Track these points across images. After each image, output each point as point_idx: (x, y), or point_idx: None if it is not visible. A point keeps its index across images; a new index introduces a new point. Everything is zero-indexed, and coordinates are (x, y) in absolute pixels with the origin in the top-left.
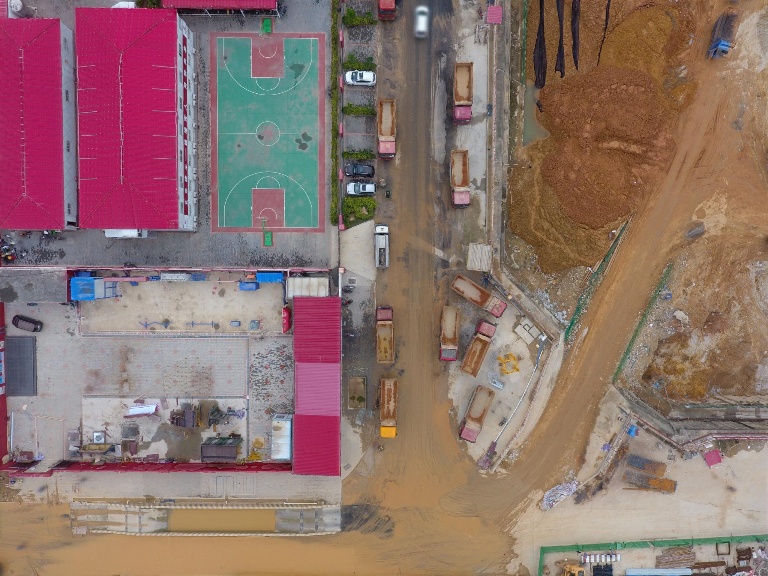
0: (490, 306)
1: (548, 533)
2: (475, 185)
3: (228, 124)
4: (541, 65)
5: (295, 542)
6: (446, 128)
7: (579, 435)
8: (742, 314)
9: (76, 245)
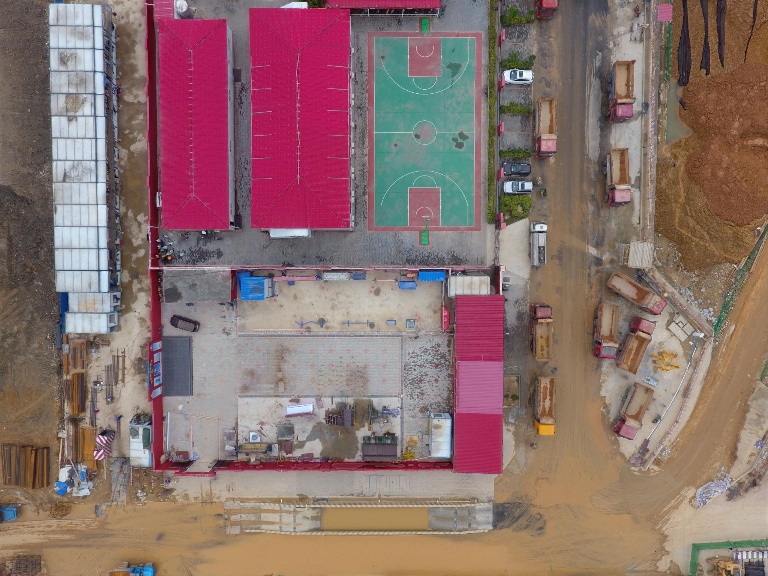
0: (651, 303)
1: (699, 530)
2: None
3: (385, 123)
4: (685, 63)
5: (447, 540)
6: (600, 126)
7: (729, 432)
8: None
9: (233, 245)
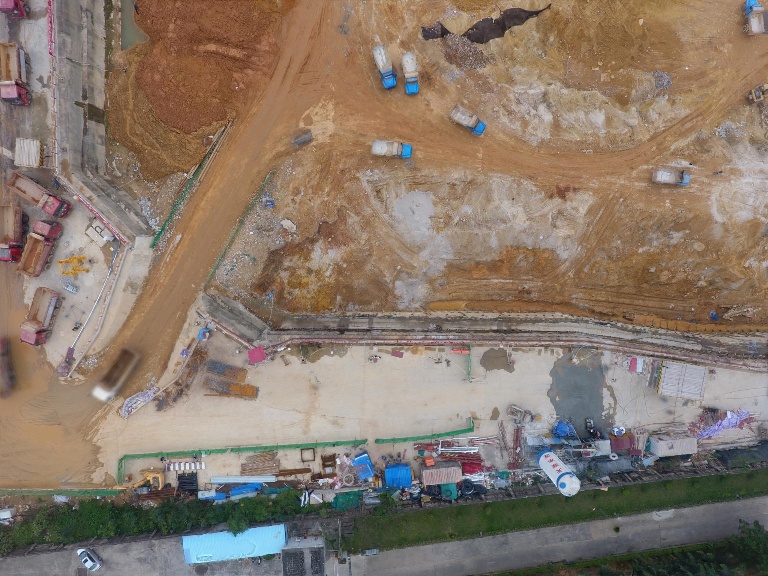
0: (40, 203)
1: (133, 441)
2: (41, 83)
3: None
4: None
5: None
6: (9, 23)
7: (166, 342)
8: (364, 226)
9: None
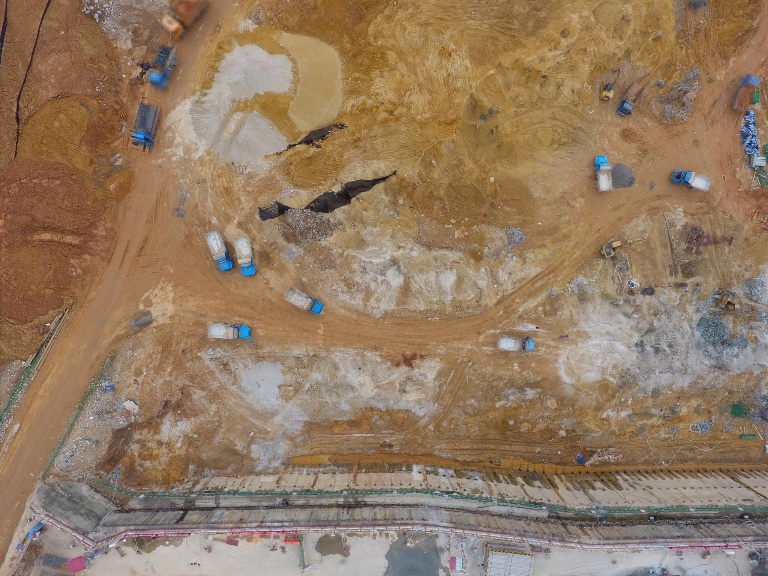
0: None
1: None
2: None
3: None
4: None
5: None
6: None
7: (4, 533)
8: (212, 399)
9: None
